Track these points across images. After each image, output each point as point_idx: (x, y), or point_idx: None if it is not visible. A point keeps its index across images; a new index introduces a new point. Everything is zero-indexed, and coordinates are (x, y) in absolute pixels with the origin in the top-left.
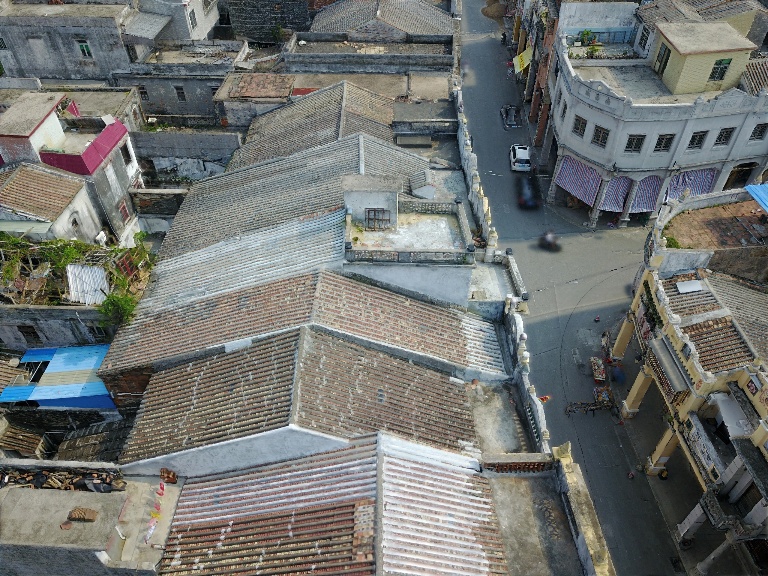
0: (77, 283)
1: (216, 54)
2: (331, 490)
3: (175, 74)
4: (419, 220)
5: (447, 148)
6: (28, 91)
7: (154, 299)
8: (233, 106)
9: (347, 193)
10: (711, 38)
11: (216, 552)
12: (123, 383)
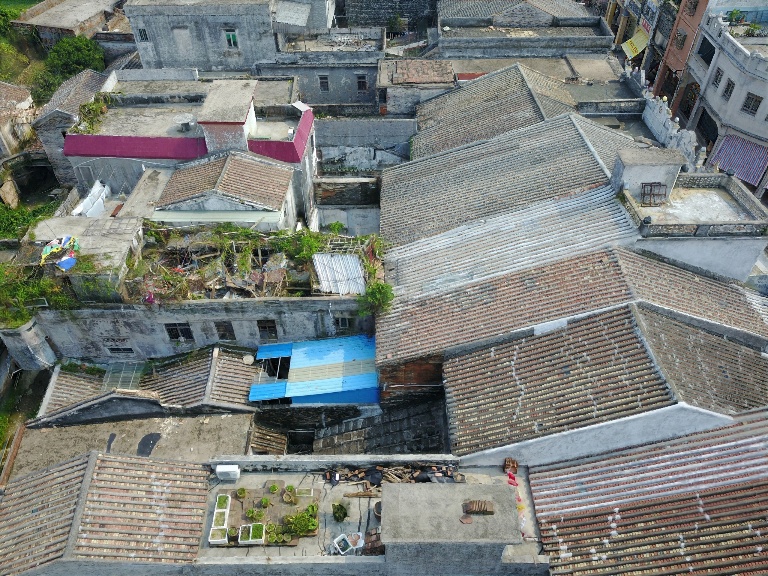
0: (327, 272)
1: (354, 43)
2: (735, 469)
3: (322, 63)
4: (689, 194)
5: (635, 128)
6: (185, 82)
7: (405, 287)
8: (396, 93)
9: (628, 167)
10: None
11: (614, 541)
12: (401, 374)
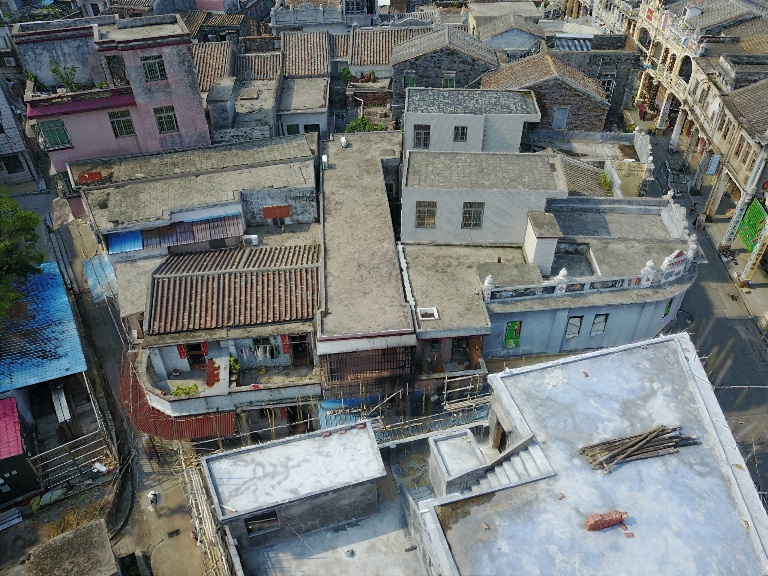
0: None
1: None
2: None
3: None
4: None
5: None
6: None
7: None
8: None
9: None
10: (501, 8)
11: None
12: None
